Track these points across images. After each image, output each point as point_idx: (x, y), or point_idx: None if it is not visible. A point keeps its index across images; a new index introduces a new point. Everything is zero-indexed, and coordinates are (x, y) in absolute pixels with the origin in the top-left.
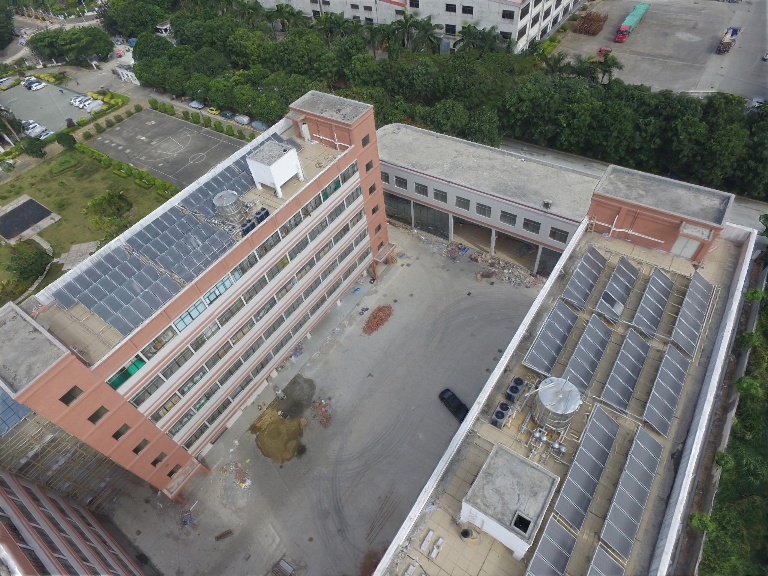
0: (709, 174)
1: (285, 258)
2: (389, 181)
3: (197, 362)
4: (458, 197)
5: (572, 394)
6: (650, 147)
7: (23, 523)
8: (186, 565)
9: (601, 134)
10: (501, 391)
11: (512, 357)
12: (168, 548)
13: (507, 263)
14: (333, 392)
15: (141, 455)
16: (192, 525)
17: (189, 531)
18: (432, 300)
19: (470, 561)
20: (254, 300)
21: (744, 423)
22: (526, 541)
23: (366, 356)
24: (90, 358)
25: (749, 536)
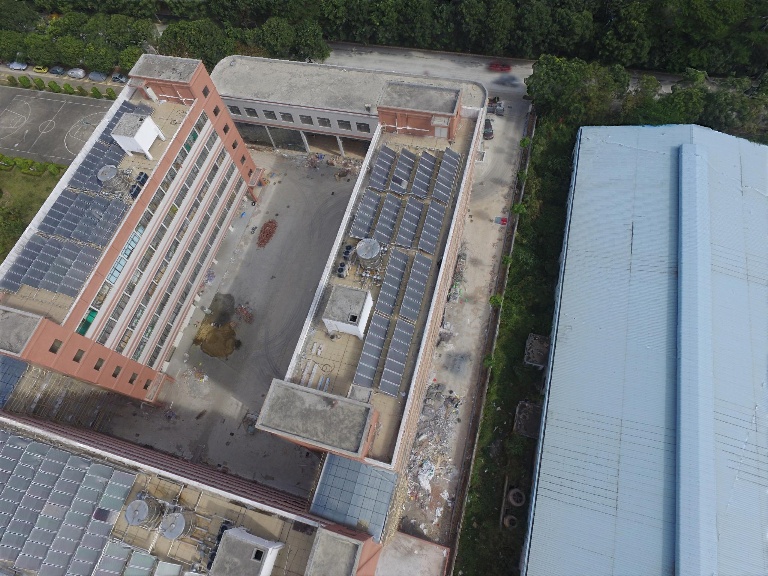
0: (493, 48)
1: (173, 207)
2: (241, 113)
3: (135, 303)
4: (301, 116)
5: (375, 246)
6: (448, 31)
7: (61, 432)
8: (181, 441)
9: (408, 27)
10: (342, 257)
11: (345, 234)
12: (164, 436)
13: (357, 160)
14: (248, 298)
15: (119, 378)
16: (175, 417)
17: (175, 421)
18: (305, 206)
19: (339, 350)
20: (161, 246)
21: (522, 234)
22: (356, 325)
23: (266, 264)
24: (55, 320)
25: (525, 300)
